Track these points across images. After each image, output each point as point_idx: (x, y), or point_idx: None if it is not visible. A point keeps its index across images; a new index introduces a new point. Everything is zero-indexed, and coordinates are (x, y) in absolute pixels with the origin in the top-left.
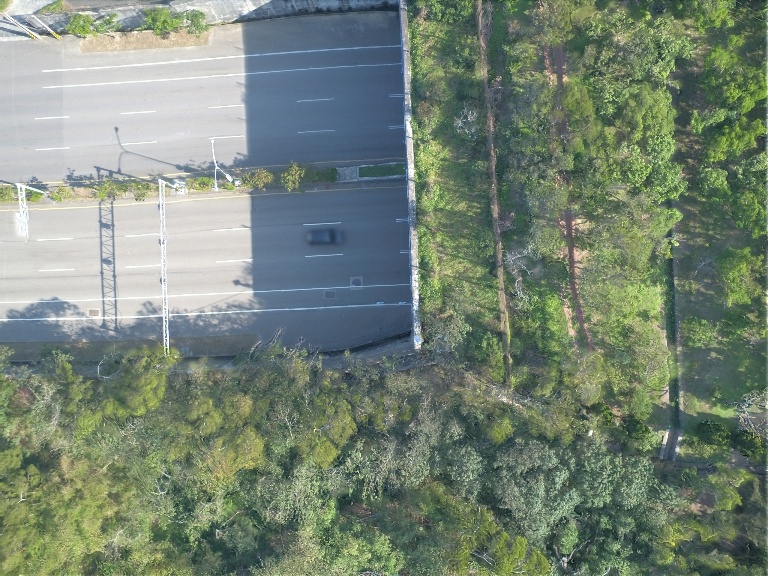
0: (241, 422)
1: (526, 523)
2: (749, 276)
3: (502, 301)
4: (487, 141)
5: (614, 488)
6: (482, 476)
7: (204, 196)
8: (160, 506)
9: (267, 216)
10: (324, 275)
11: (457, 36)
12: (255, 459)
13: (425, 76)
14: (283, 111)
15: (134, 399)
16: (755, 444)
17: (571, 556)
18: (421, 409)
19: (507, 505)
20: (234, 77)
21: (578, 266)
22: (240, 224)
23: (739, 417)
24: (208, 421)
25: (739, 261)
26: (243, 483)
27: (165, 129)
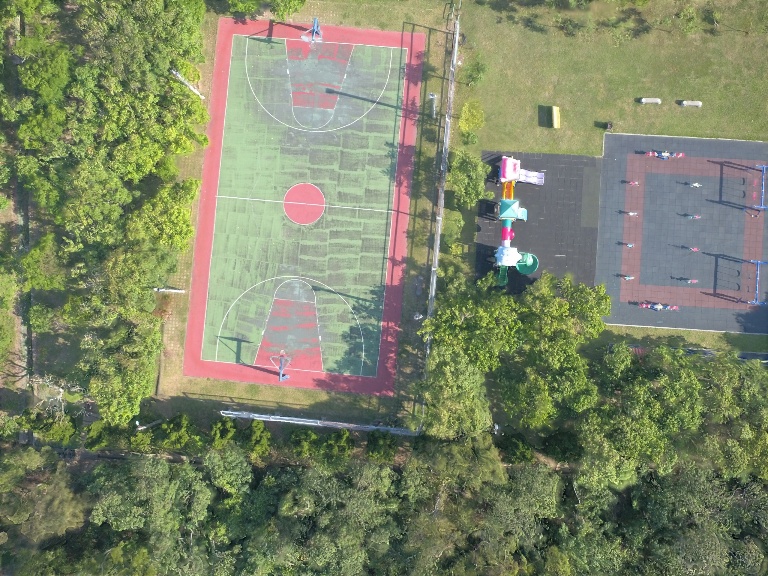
0: None
1: None
2: (58, 262)
3: None
4: None
5: None
6: None
7: None
8: None
9: None
10: None
11: None
12: None
13: None
14: None
15: None
16: None
17: None
18: None
19: None
20: None
21: None
22: None
23: (84, 402)
24: None
25: None
26: None
27: None
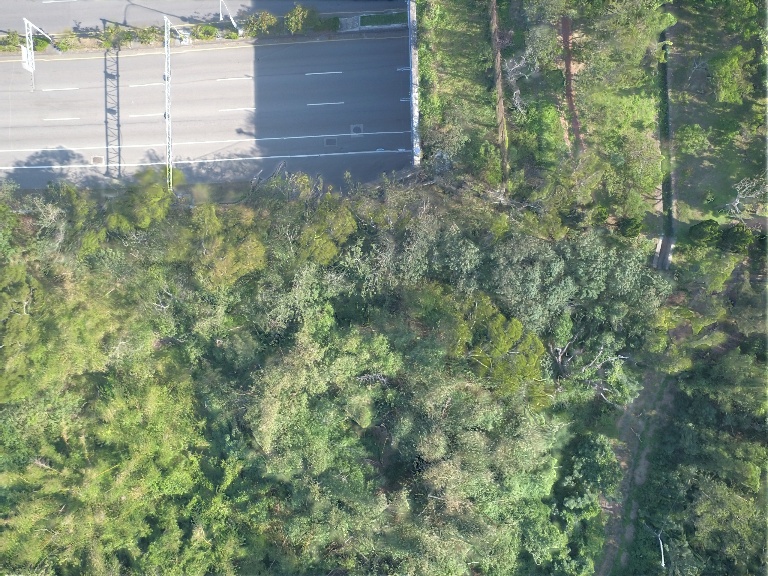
0: (243, 233)
1: (522, 308)
2: None
3: (500, 110)
4: None
5: (608, 275)
6: (479, 270)
7: (208, 47)
8: (161, 325)
9: (270, 66)
10: (325, 123)
11: None
12: (256, 265)
13: None
14: None
15: (138, 210)
16: (746, 234)
17: (566, 349)
18: (420, 213)
19: (503, 290)
20: None
21: (575, 79)
22: (243, 74)
23: (731, 223)
24: (210, 229)
25: (731, 58)
26: (244, 297)
27: None
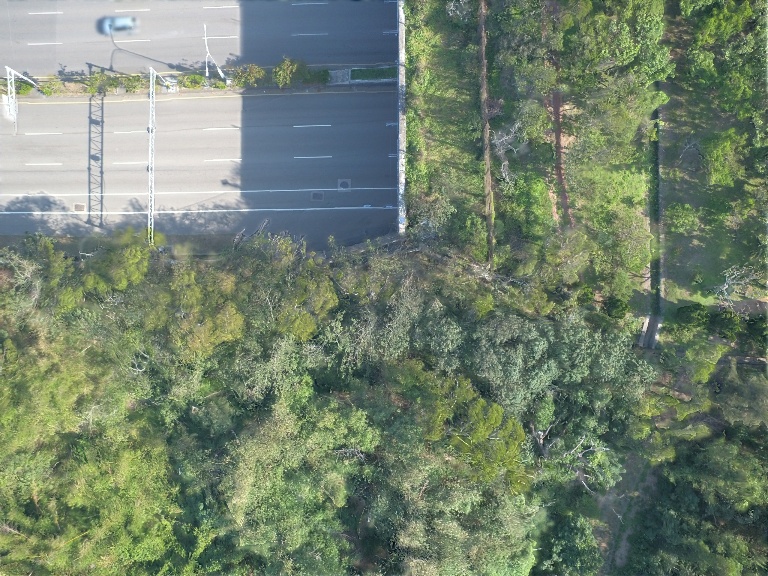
0: (222, 298)
1: (503, 392)
2: (733, 158)
3: (488, 182)
4: (478, 25)
5: (592, 360)
6: (461, 349)
7: (195, 95)
8: (137, 387)
9: (257, 117)
10: (312, 177)
11: None
12: (234, 333)
13: None
14: (278, 14)
15: (115, 272)
16: (734, 322)
17: (547, 432)
18: (403, 286)
19: (485, 373)
20: None
21: (564, 151)
22: (230, 124)
23: (719, 305)
24: (189, 294)
25: (723, 141)
26: (222, 362)
27: (159, 28)
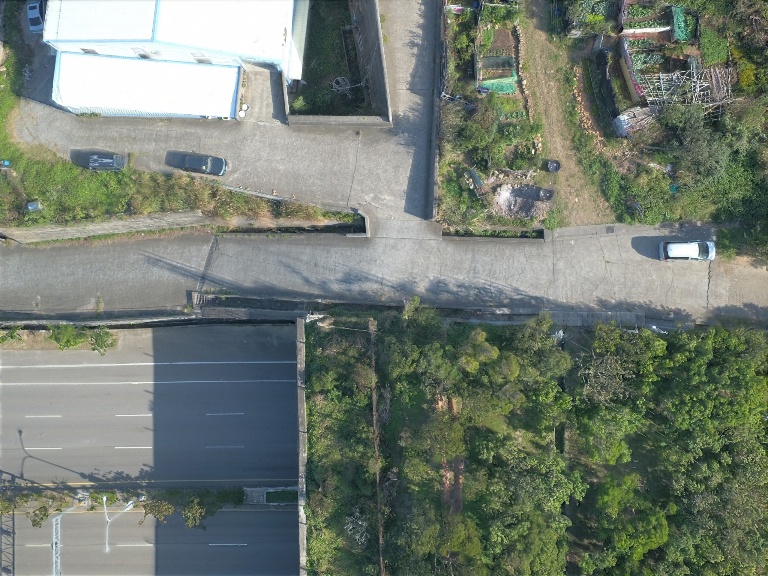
0: None
1: None
2: None
3: None
4: None
5: None
6: None
7: (108, 508)
8: None
9: (172, 533)
10: None
11: (355, 418)
12: None
13: (320, 460)
14: (192, 423)
15: None
16: None
17: None
18: None
19: None
20: (143, 385)
21: None
22: (144, 540)
23: None
24: None
25: None
26: None
27: (70, 435)
